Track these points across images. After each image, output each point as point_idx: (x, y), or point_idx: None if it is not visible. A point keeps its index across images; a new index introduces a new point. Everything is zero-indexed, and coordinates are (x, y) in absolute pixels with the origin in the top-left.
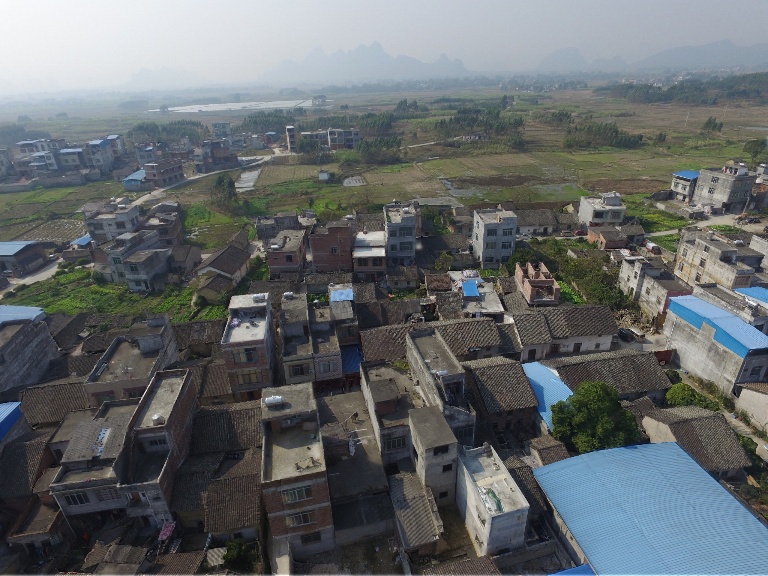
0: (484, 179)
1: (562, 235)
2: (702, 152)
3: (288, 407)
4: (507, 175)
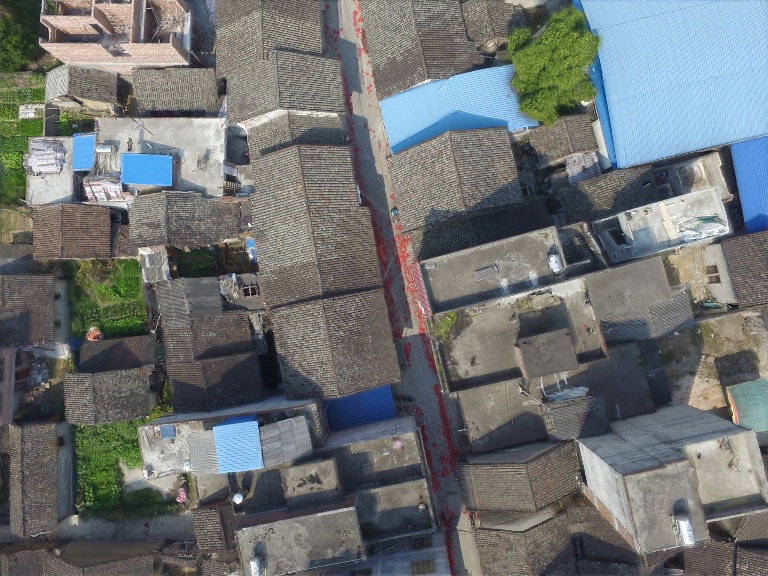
0: None
1: None
2: None
3: (685, 504)
4: None
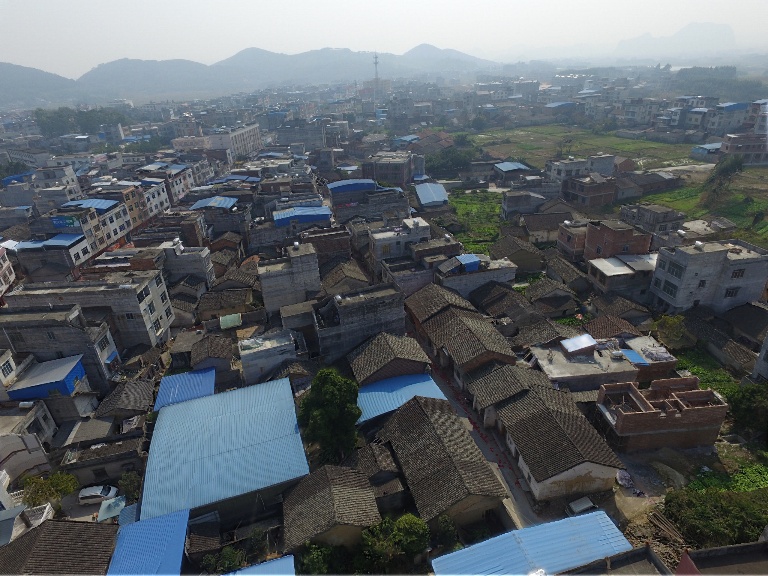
0: None
1: None
2: None
3: None
4: None
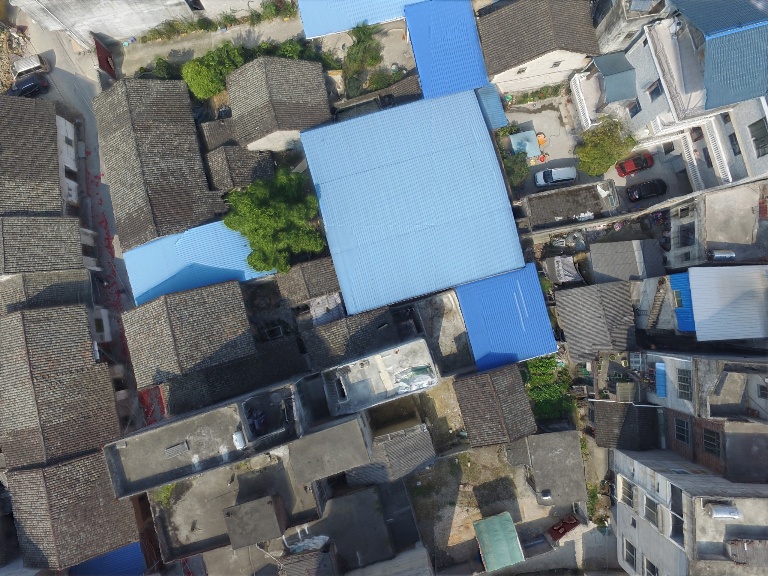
0: None
1: None
2: None
3: None
4: None
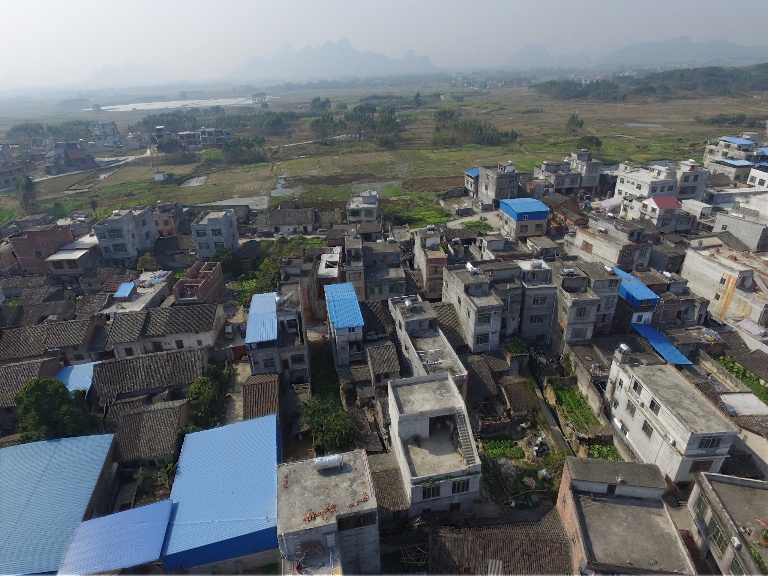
0: (320, 178)
1: (318, 233)
2: (555, 148)
3: None
4: (347, 174)
